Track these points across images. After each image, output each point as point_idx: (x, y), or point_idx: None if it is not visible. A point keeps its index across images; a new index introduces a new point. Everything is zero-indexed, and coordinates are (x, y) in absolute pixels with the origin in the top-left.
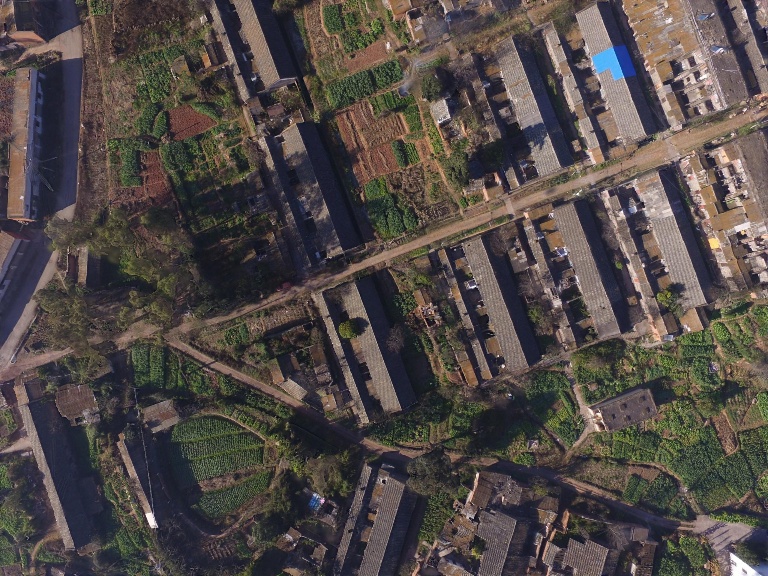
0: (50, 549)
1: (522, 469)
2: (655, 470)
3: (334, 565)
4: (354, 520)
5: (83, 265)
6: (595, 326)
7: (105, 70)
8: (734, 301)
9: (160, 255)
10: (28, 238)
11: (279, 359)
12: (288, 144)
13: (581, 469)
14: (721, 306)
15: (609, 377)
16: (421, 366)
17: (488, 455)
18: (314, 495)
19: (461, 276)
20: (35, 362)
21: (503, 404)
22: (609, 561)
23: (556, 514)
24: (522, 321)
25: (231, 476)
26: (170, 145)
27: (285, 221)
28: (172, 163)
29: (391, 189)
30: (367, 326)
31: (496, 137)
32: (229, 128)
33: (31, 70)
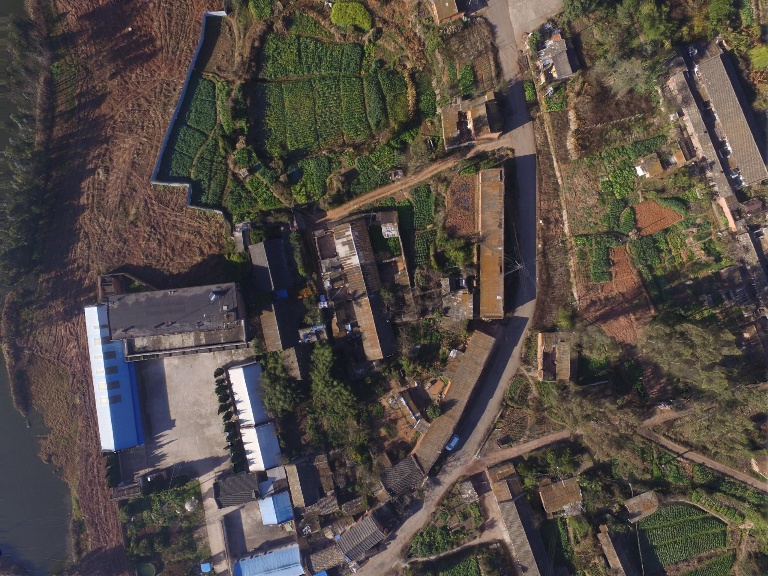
0: None
1: None
2: None
3: None
4: None
5: (564, 363)
6: None
7: (566, 167)
8: None
9: (631, 349)
10: (490, 334)
11: (767, 449)
12: None
13: None
14: None
15: None
16: None
17: None
18: None
19: None
20: (500, 456)
21: None
22: None
23: None
24: None
25: (695, 560)
26: (641, 241)
27: (757, 312)
28: (643, 259)
29: None
30: None
31: None
32: (696, 222)
33: (503, 171)
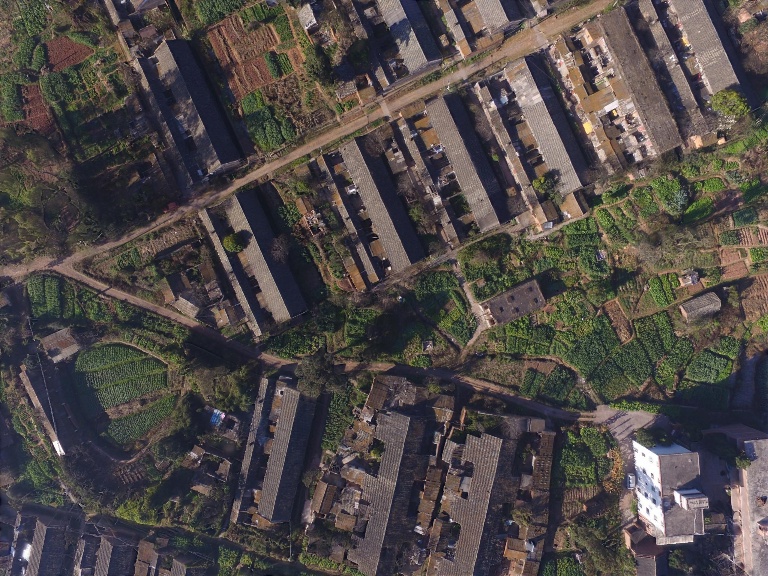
0: None
1: (419, 372)
2: (551, 363)
3: (239, 479)
4: (255, 432)
5: None
6: (476, 220)
7: None
8: (613, 185)
9: None
10: None
11: (168, 278)
12: (161, 63)
13: (477, 367)
14: (601, 191)
15: (497, 272)
16: (312, 277)
17: (382, 359)
18: (215, 411)
19: (342, 182)
20: None
21: (394, 308)
22: (505, 452)
23: (452, 411)
24: (403, 220)
25: (137, 402)
26: (49, 76)
27: (167, 143)
28: (52, 94)
29: (267, 101)
30: (251, 238)
31: (363, 38)
32: (106, 55)
33: None
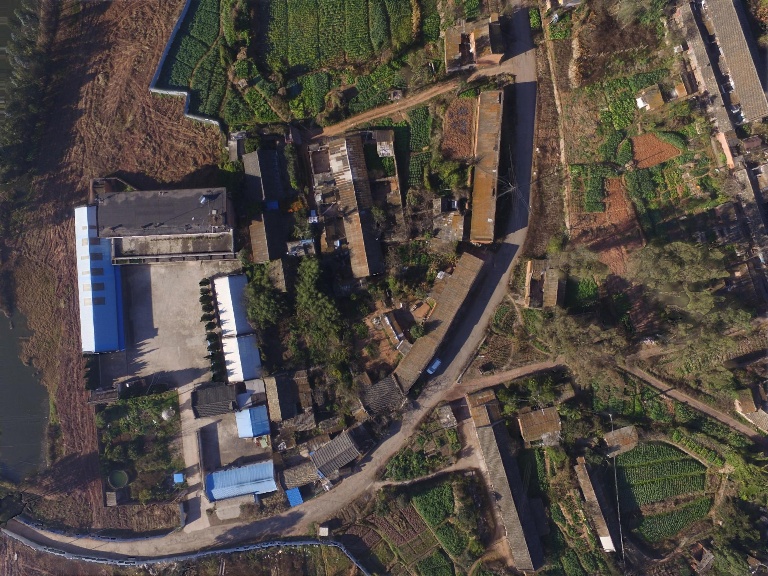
0: (490, 568)
1: None
2: None
3: None
4: None
5: (551, 290)
6: None
7: (566, 95)
8: None
9: (620, 282)
10: None
11: (752, 390)
12: None
13: None
14: None
15: None
16: None
17: None
18: None
19: None
20: (482, 383)
21: None
22: None
23: None
24: None
25: (672, 501)
26: (637, 173)
27: (750, 252)
28: (638, 191)
29: None
30: None
31: None
32: (694, 158)
33: None
